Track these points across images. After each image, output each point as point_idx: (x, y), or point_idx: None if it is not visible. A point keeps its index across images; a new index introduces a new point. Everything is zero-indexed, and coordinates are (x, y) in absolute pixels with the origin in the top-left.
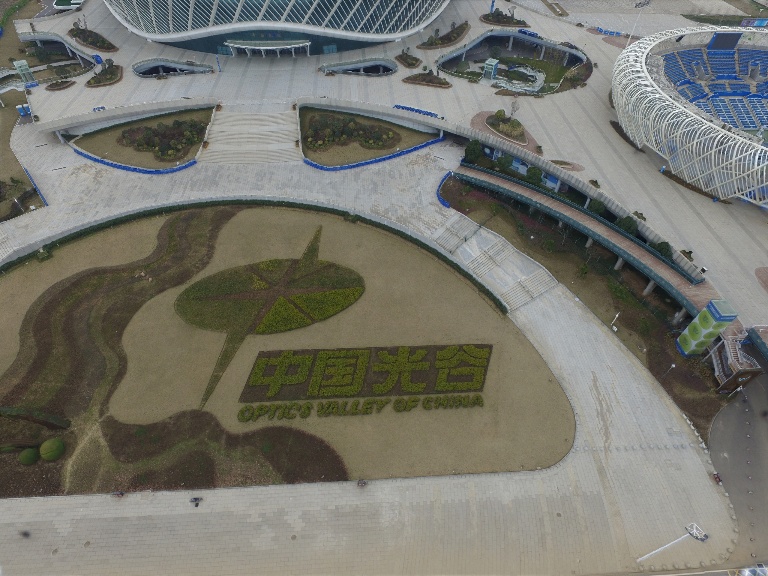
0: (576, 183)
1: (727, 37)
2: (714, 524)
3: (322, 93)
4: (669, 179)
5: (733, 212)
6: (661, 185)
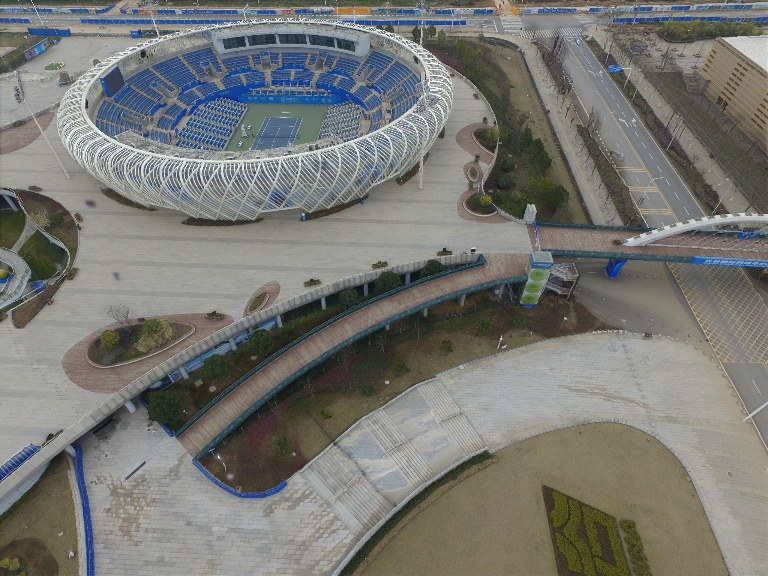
0: (303, 300)
1: (112, 77)
2: (687, 354)
3: None
4: (318, 219)
5: (381, 198)
6: (327, 229)
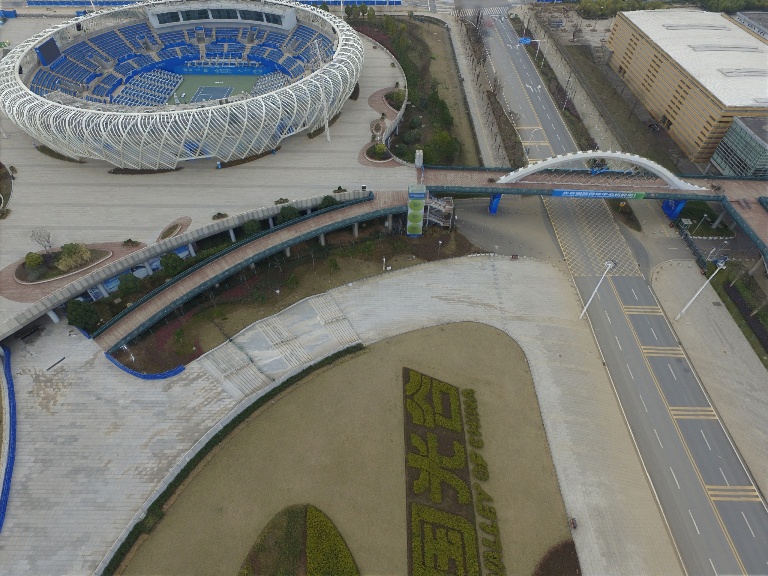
0: (210, 230)
1: (47, 47)
2: (545, 271)
3: None
4: (233, 167)
5: (291, 150)
6: (240, 175)
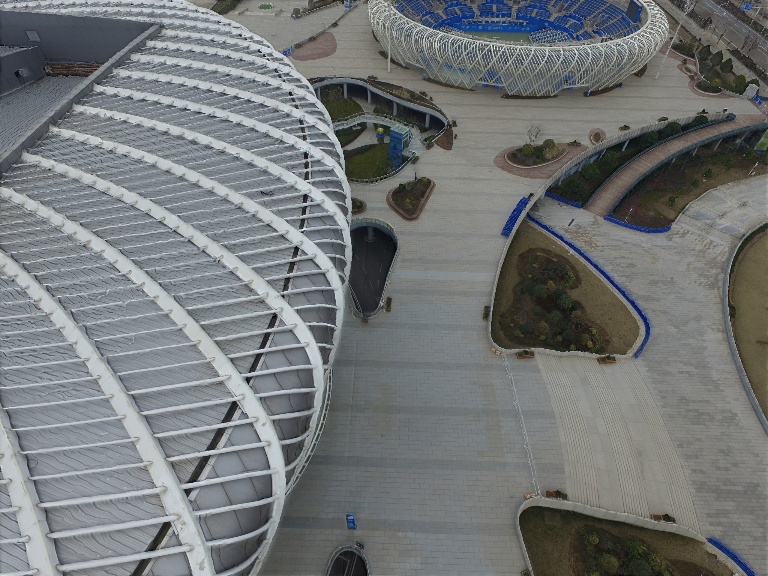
0: (624, 137)
1: None
2: None
3: (461, 317)
4: (597, 96)
5: (632, 85)
6: (608, 101)
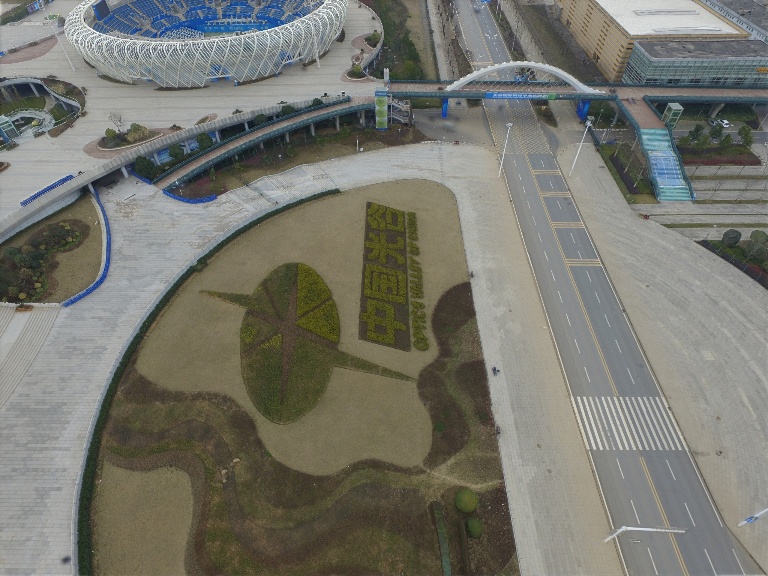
0: (231, 121)
1: (101, 6)
2: (478, 151)
3: None
4: (246, 85)
5: (290, 74)
6: (252, 89)
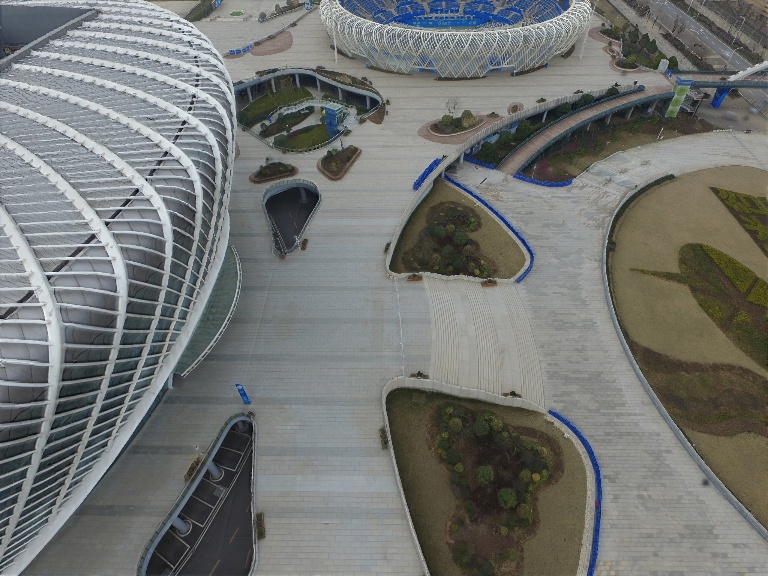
0: (540, 109)
1: None
2: None
3: (365, 252)
4: (523, 75)
5: (557, 65)
6: (532, 79)
